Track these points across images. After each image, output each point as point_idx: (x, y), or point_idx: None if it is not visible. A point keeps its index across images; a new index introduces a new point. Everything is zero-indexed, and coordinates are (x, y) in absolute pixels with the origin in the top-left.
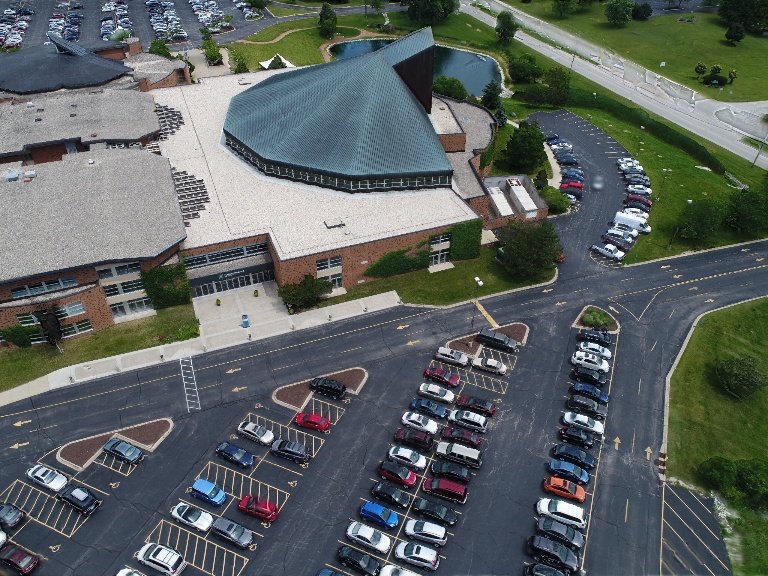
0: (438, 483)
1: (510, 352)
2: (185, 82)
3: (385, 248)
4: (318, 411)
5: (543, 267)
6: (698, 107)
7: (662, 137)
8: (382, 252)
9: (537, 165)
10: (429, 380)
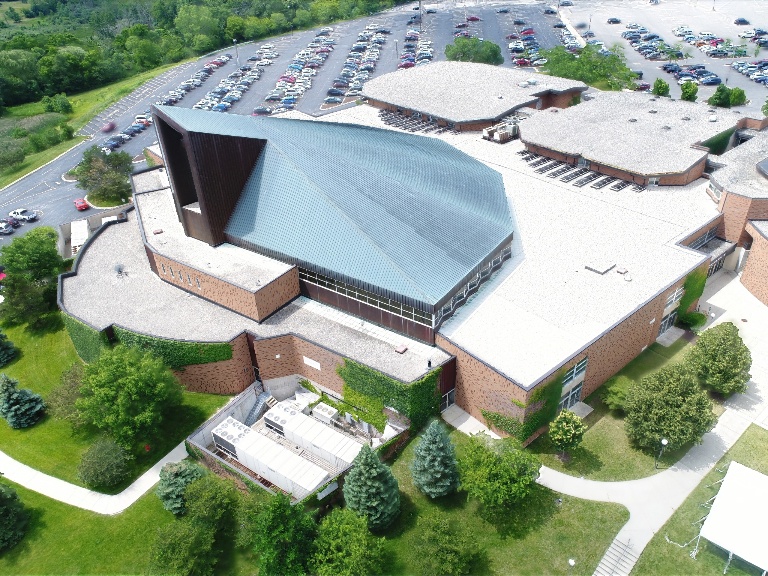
0: None
1: None
2: None
3: None
4: None
5: None
6: None
7: None
8: None
9: None
10: None
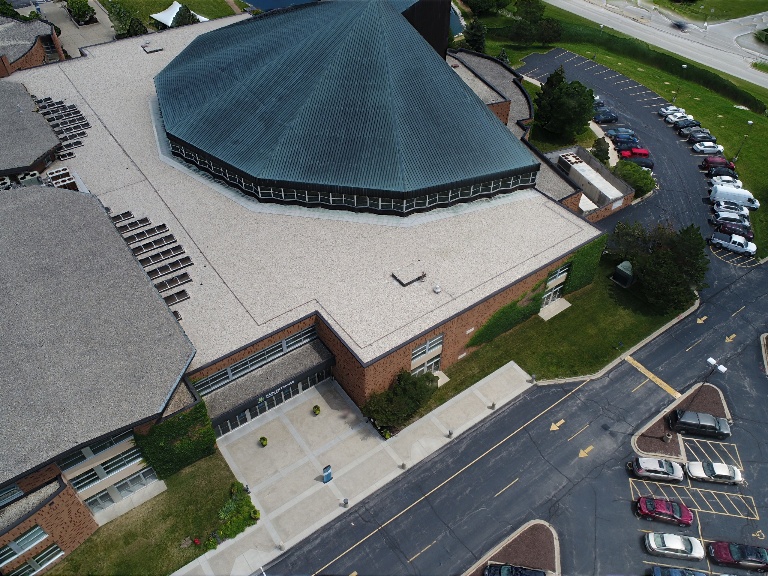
0: None
1: (723, 439)
2: (56, 54)
3: (497, 304)
4: None
5: (691, 288)
6: (711, 32)
7: (677, 72)
8: (492, 310)
9: (585, 130)
10: (647, 520)
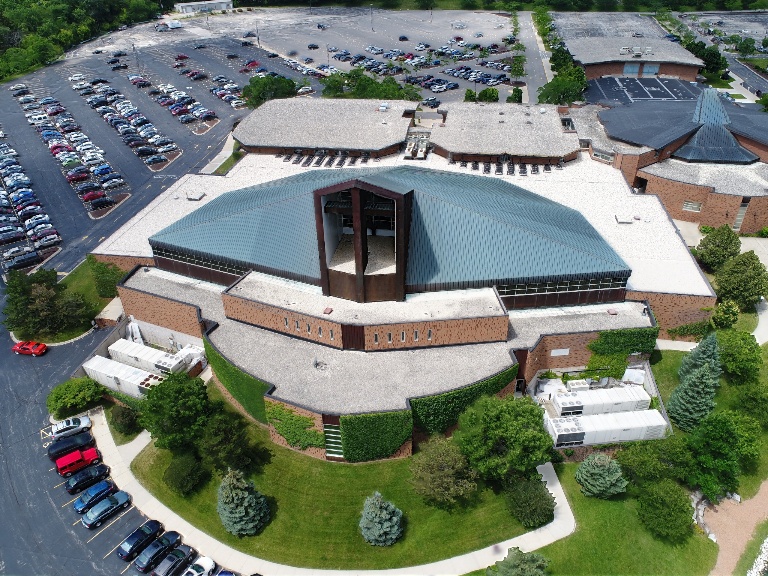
0: (2, 209)
1: None
2: None
3: None
4: None
5: None
6: None
7: None
8: None
9: None
10: None
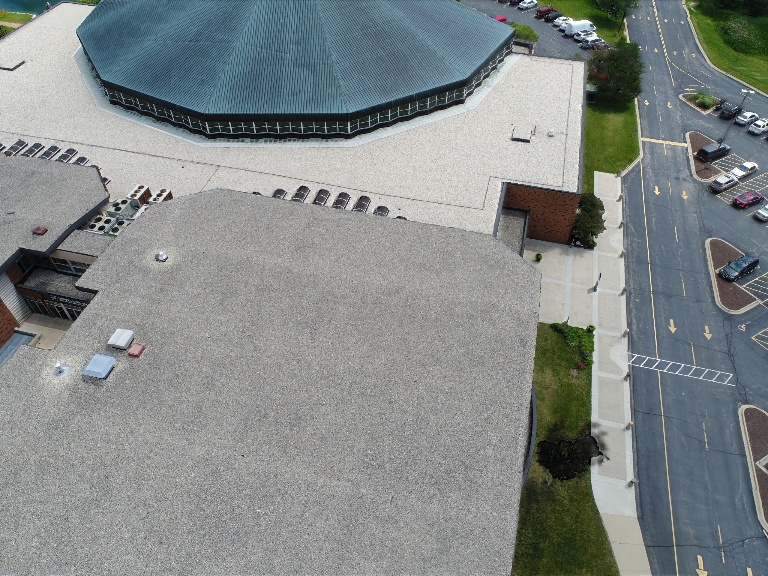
0: None
1: (728, 154)
2: None
3: None
4: (765, 290)
5: None
6: None
7: None
8: None
9: None
10: (745, 209)
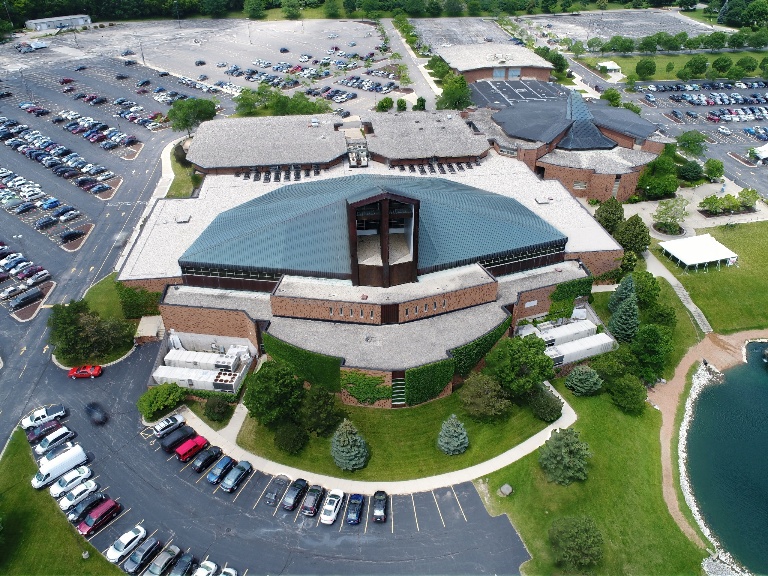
0: None
1: None
2: None
3: None
4: None
5: None
6: None
7: None
8: None
9: None
10: None
